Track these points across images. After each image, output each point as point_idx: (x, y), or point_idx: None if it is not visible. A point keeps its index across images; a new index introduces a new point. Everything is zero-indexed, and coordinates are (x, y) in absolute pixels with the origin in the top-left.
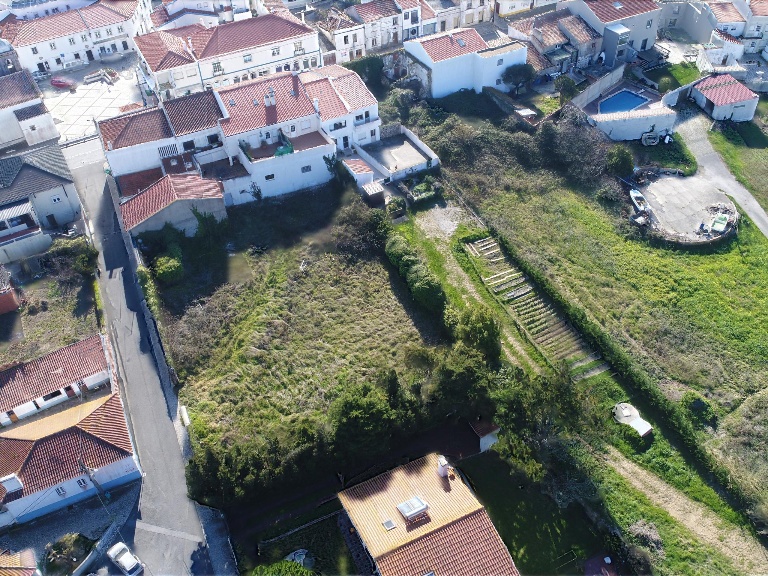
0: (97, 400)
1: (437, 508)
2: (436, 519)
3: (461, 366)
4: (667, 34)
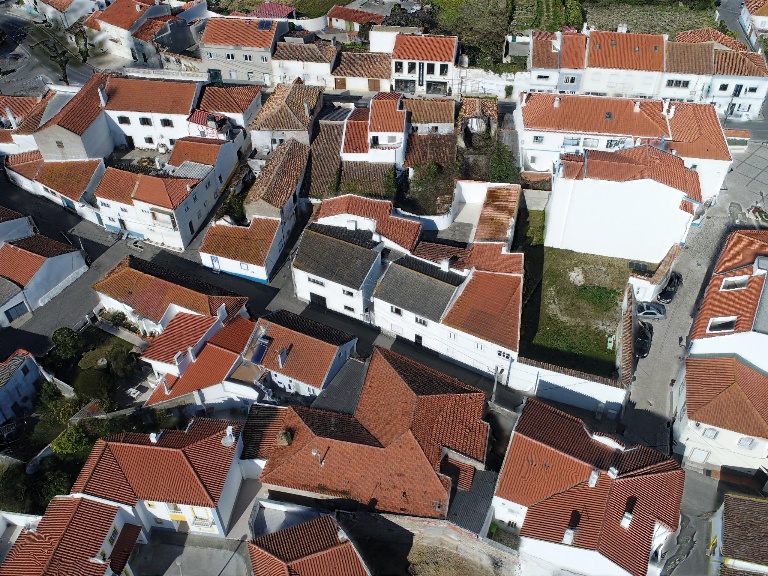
0: (762, 14)
1: None
2: None
3: None
4: None
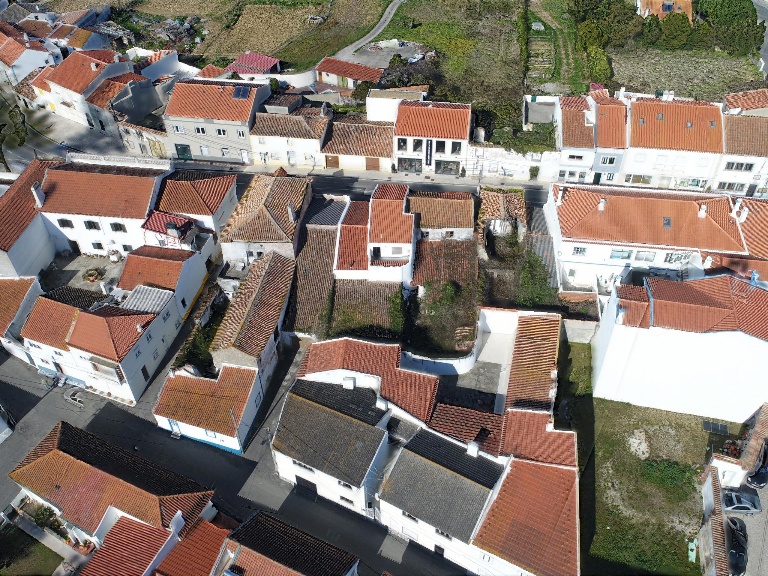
0: None
1: (658, 5)
2: (661, 2)
3: (625, 4)
4: (156, 126)
